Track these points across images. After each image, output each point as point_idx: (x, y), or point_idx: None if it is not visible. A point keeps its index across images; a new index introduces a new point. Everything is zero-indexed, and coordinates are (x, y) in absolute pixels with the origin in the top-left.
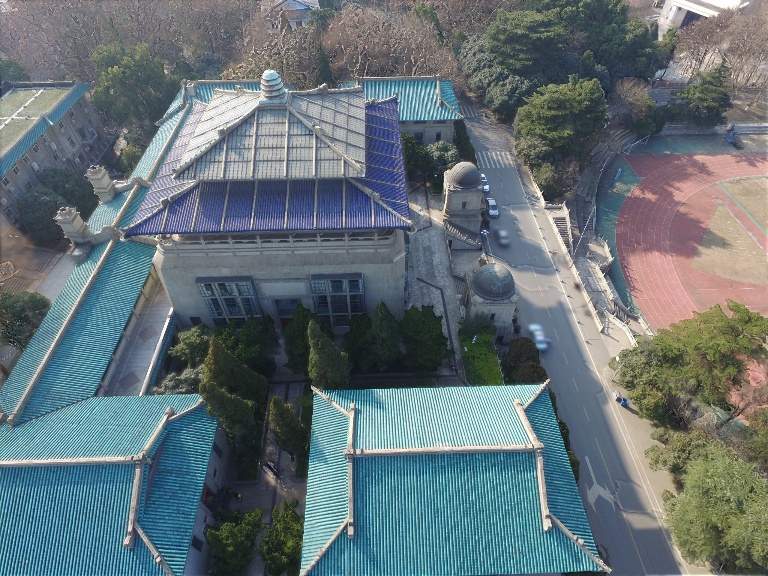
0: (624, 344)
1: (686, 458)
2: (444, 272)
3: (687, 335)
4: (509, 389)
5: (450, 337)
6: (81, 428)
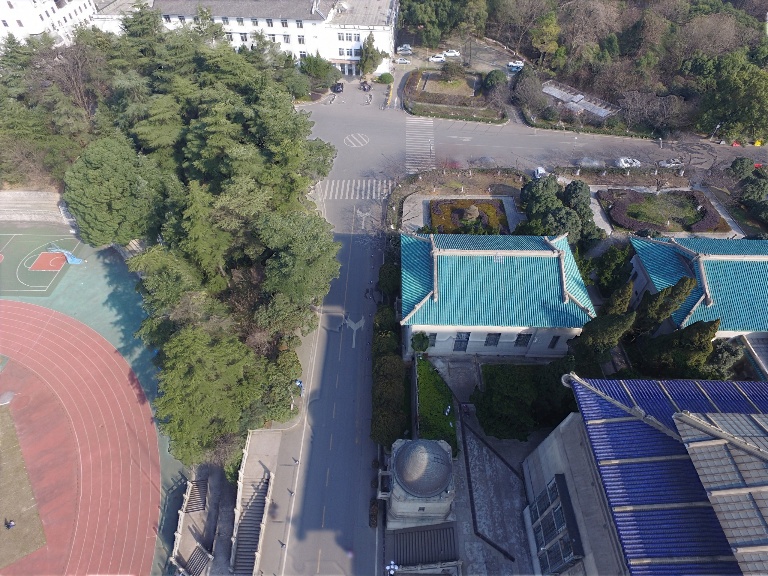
0: (255, 457)
1: (296, 311)
2: (472, 573)
3: (235, 377)
4: (436, 319)
5: (466, 450)
6: (766, 292)
